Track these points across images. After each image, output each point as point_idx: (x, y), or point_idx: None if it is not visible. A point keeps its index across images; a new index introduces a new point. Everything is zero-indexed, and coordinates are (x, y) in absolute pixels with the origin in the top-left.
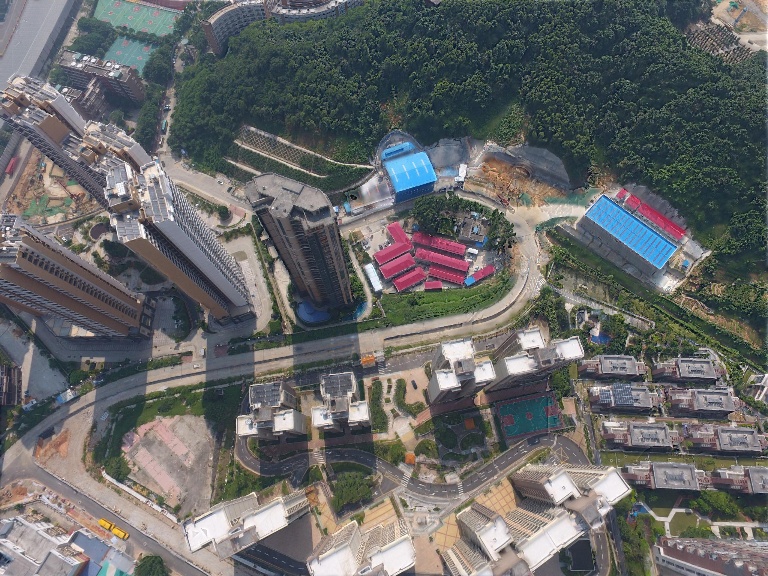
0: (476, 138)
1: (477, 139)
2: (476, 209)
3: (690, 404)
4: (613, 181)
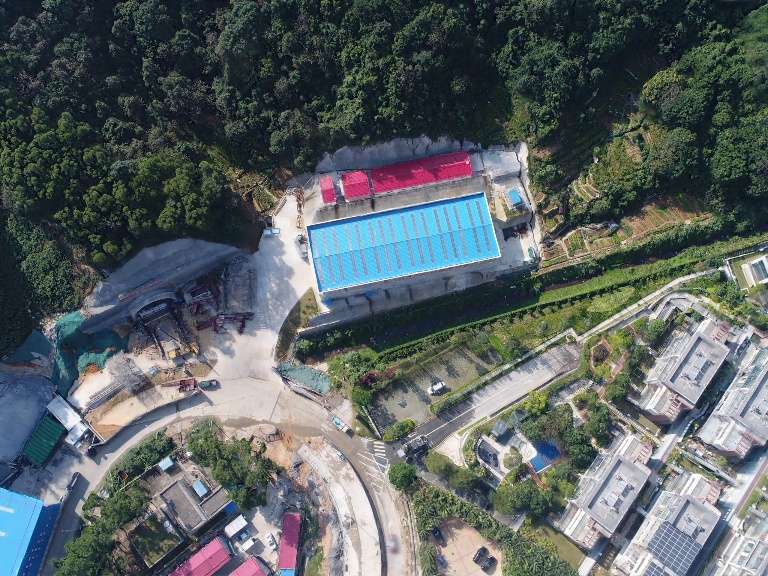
0: (17, 345)
1: (21, 344)
2: (160, 452)
3: (750, 443)
4: (293, 175)
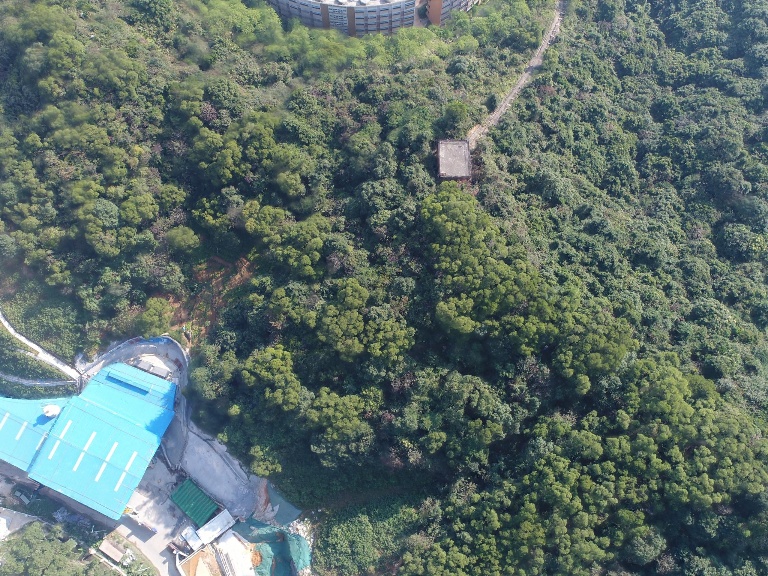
0: (285, 497)
1: (286, 500)
2: None
3: None
4: None
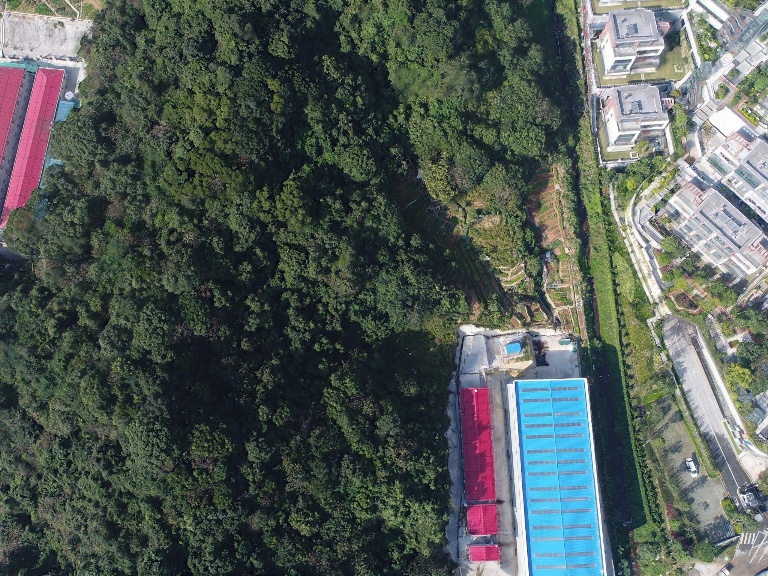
0: None
1: None
2: None
3: None
4: None
